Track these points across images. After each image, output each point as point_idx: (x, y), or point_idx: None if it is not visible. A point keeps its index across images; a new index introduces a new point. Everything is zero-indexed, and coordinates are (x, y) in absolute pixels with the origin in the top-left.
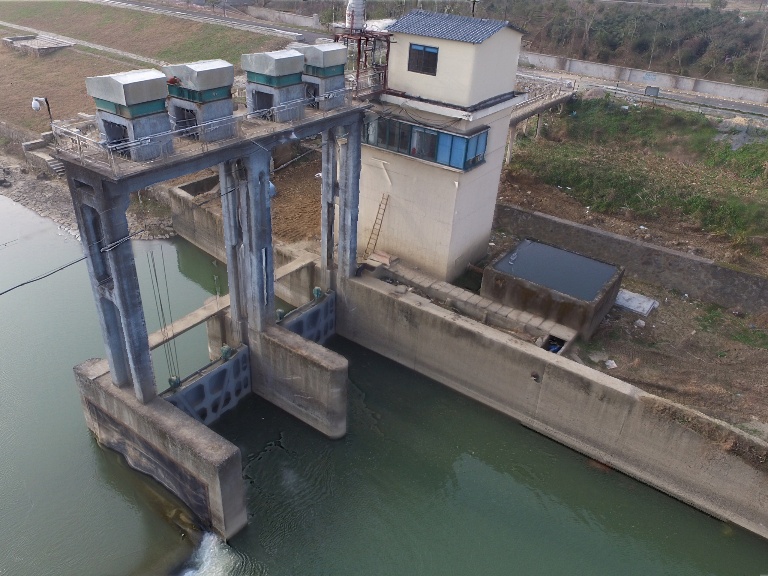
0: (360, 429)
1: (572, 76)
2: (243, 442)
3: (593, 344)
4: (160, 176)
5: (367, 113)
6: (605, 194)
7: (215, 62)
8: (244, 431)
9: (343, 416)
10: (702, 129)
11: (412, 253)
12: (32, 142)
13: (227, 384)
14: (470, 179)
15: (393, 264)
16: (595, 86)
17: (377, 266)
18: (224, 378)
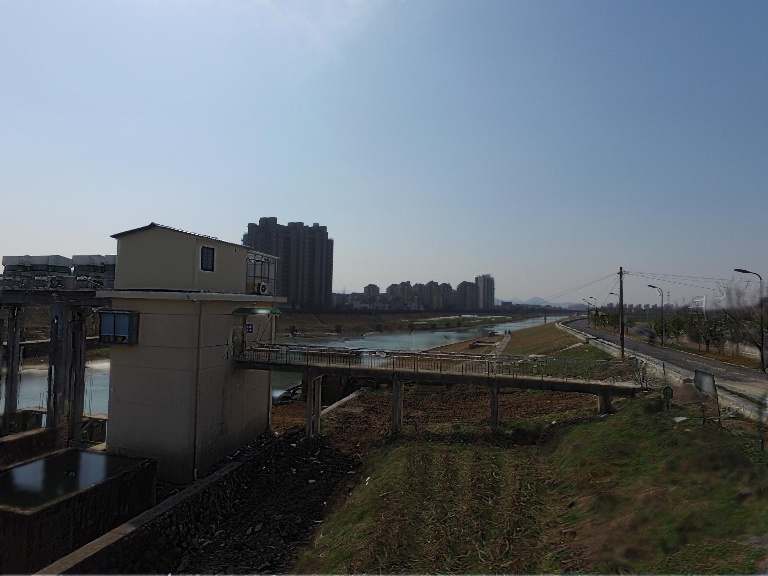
0: None
1: None
2: None
3: None
4: (8, 299)
5: None
6: None
7: None
8: None
9: None
10: (753, 500)
11: None
12: None
13: None
14: (130, 362)
15: None
16: None
17: None
18: None
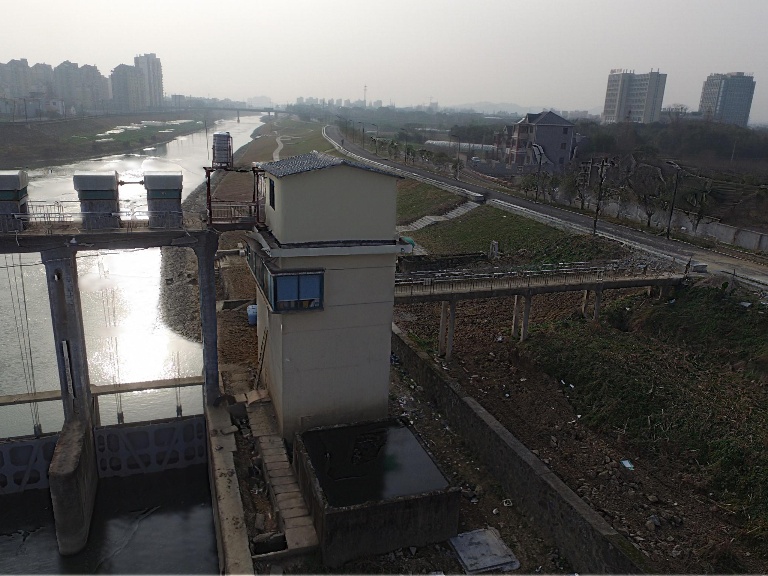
0: (93, 557)
1: (742, 262)
2: (4, 519)
3: (335, 571)
4: None
5: (184, 236)
6: (605, 404)
7: (9, 171)
8: (20, 511)
9: (67, 531)
10: None
11: (274, 398)
12: None
13: (35, 462)
14: (312, 326)
15: (257, 405)
16: (727, 273)
17: (239, 401)
18: (31, 454)
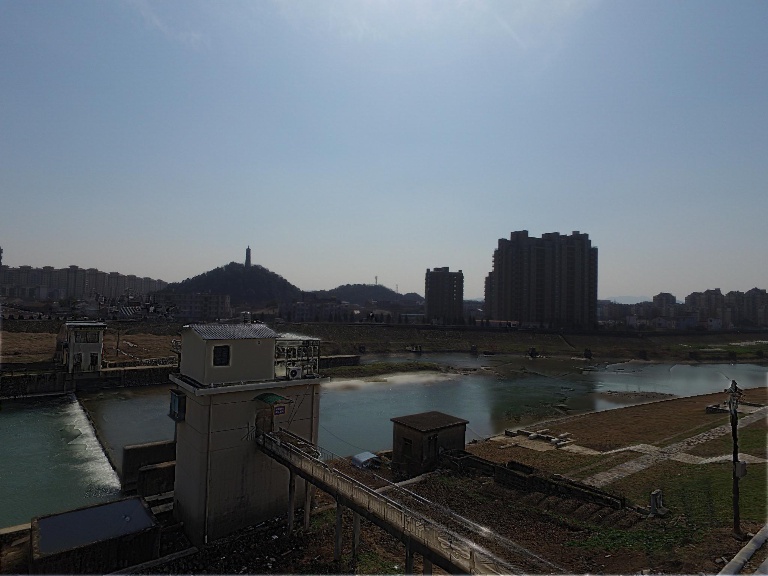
0: None
1: None
2: None
3: None
4: None
5: None
6: None
7: None
8: None
9: None
10: None
11: None
12: (510, 431)
13: None
14: None
15: None
16: None
17: None
18: None
